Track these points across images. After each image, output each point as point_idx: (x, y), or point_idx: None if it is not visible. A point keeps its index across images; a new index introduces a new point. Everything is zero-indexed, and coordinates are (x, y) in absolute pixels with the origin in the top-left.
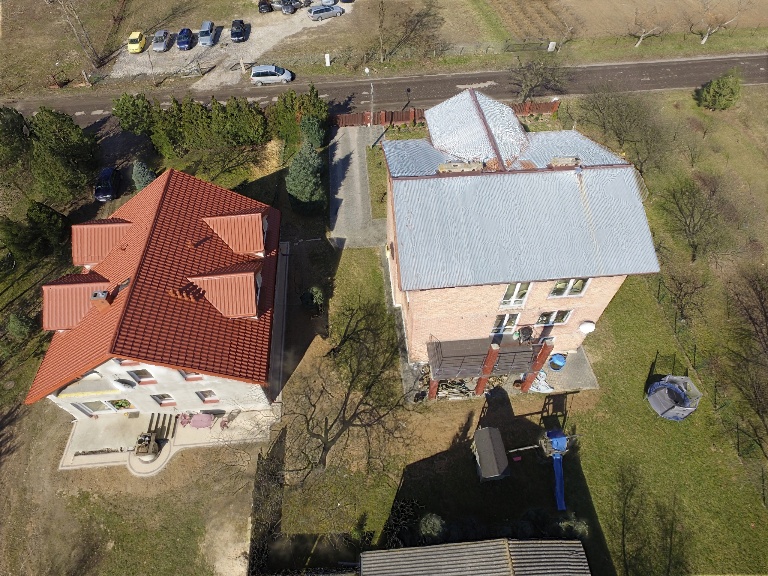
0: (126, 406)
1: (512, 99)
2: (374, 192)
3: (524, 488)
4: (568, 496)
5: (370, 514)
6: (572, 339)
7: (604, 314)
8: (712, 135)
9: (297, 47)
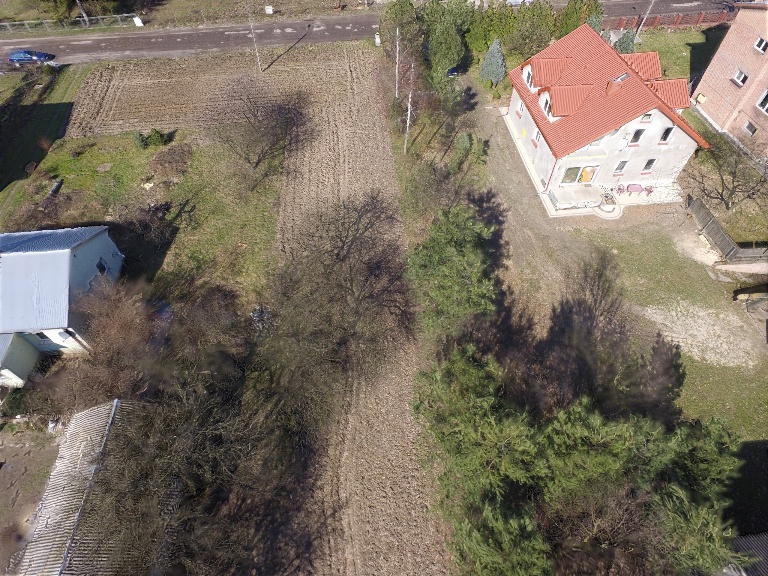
0: (580, 181)
1: None
2: None
3: None
4: None
5: None
6: None
7: None
8: None
9: None
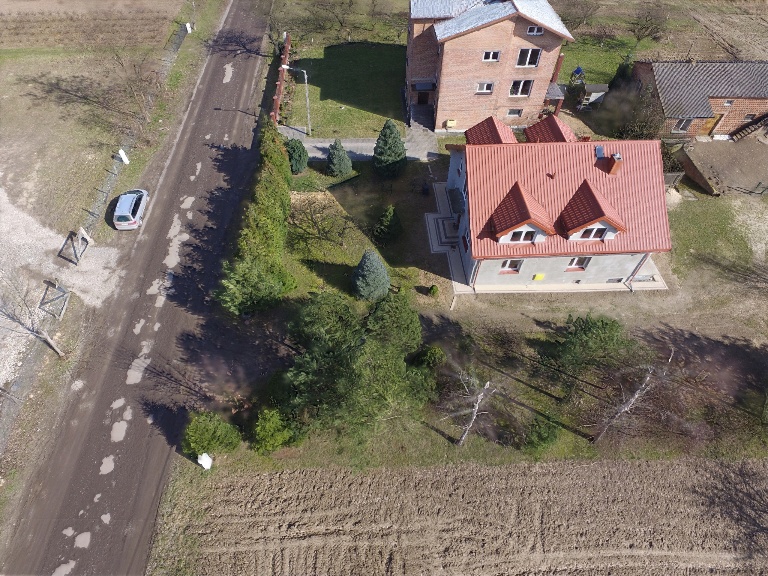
0: None
1: (258, 60)
2: (373, 136)
3: None
4: None
5: None
6: None
7: None
8: (332, 2)
9: (54, 191)
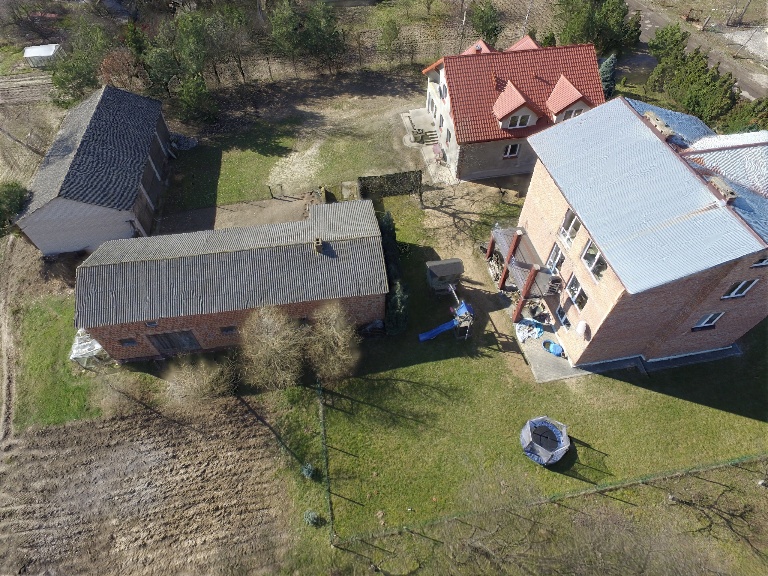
0: None
1: None
2: None
3: (431, 315)
4: (431, 344)
5: (399, 232)
6: (576, 343)
7: (637, 405)
8: None
9: None
